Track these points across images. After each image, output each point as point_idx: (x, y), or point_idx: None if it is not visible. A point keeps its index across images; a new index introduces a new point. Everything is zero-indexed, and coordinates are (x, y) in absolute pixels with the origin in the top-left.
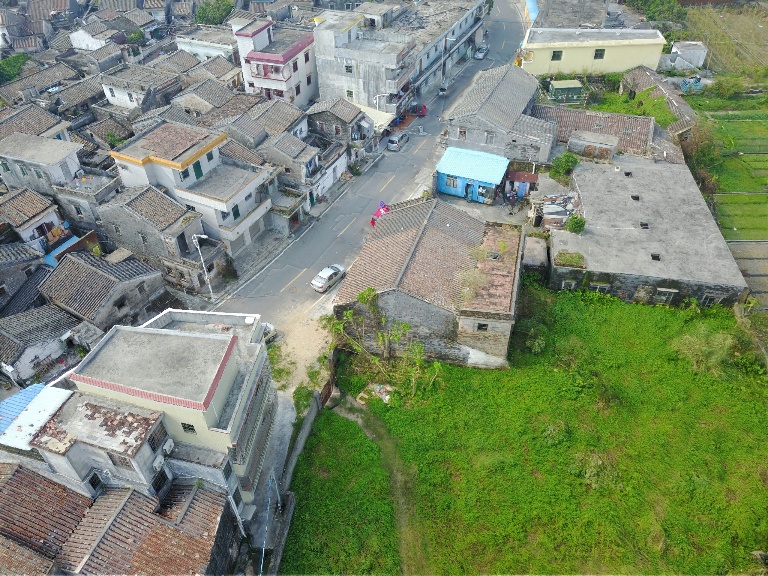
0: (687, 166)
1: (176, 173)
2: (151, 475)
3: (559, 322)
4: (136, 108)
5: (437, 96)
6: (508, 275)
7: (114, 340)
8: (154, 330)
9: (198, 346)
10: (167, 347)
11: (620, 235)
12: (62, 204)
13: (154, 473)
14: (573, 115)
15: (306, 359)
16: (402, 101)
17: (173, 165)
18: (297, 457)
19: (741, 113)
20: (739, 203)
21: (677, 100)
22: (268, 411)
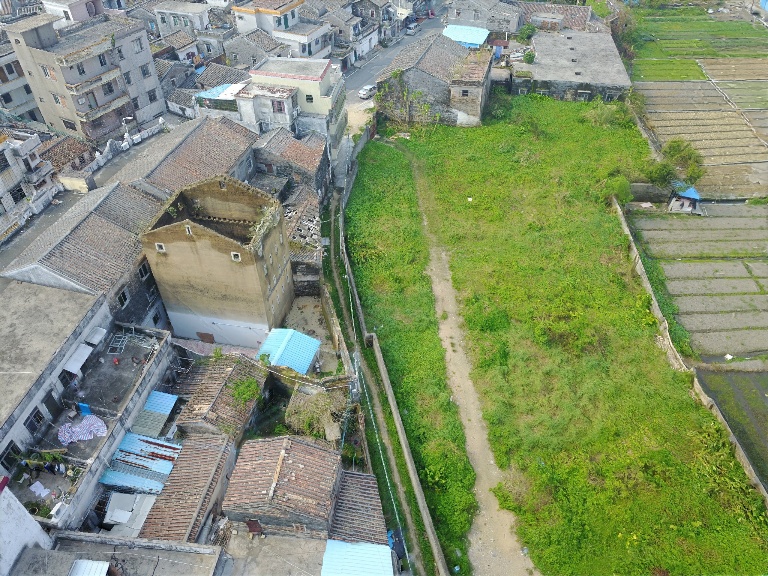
0: (610, 34)
1: (275, 20)
2: (291, 120)
3: (514, 107)
4: (231, 2)
5: (442, 7)
6: (482, 70)
7: (267, 63)
8: (288, 59)
9: (312, 64)
10: (296, 64)
11: (557, 64)
12: (198, 45)
13: (292, 120)
14: (536, 7)
15: (358, 125)
16: (417, 2)
17: (274, 12)
18: (358, 153)
19: (665, 18)
20: (648, 64)
21: (614, 3)
22: (344, 116)
